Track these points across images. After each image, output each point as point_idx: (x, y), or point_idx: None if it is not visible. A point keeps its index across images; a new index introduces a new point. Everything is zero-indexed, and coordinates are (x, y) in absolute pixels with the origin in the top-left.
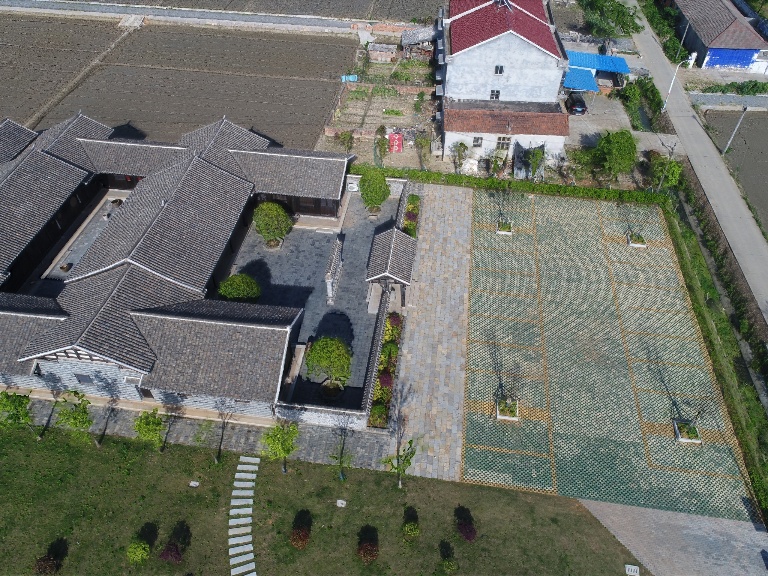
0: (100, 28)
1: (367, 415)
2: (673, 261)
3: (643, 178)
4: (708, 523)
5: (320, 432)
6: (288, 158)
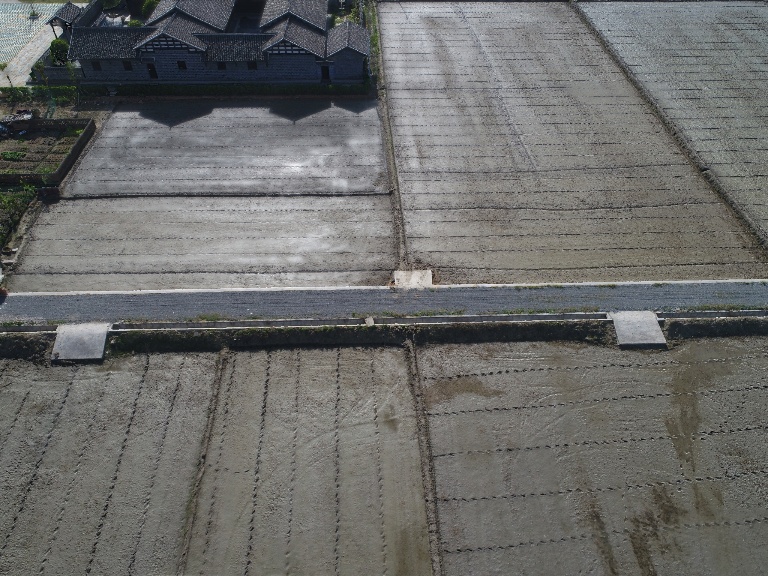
0: (456, 263)
1: None
2: None
3: None
4: None
5: None
6: None
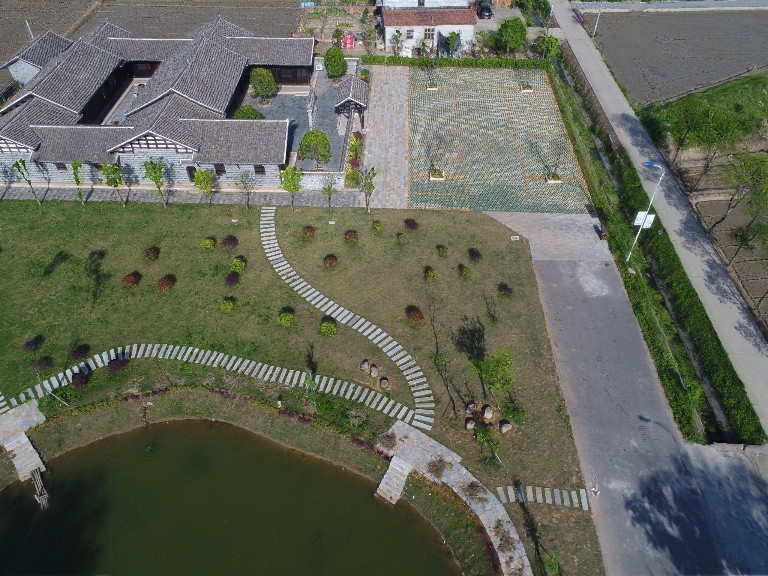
0: None
1: (344, 174)
2: (552, 98)
3: (534, 55)
4: (563, 216)
5: (313, 193)
6: (271, 40)
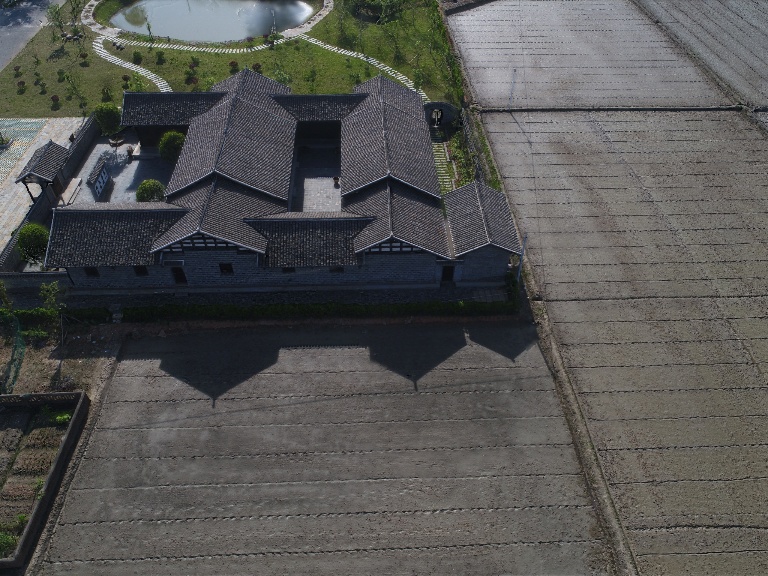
0: None
1: None
2: None
3: None
4: None
5: None
6: None
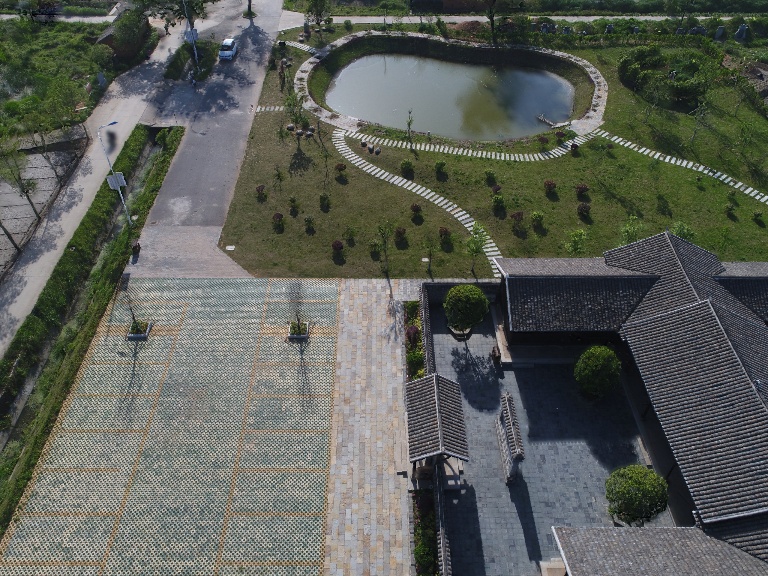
0: None
1: (420, 284)
2: None
3: None
4: (163, 274)
5: None
6: None
